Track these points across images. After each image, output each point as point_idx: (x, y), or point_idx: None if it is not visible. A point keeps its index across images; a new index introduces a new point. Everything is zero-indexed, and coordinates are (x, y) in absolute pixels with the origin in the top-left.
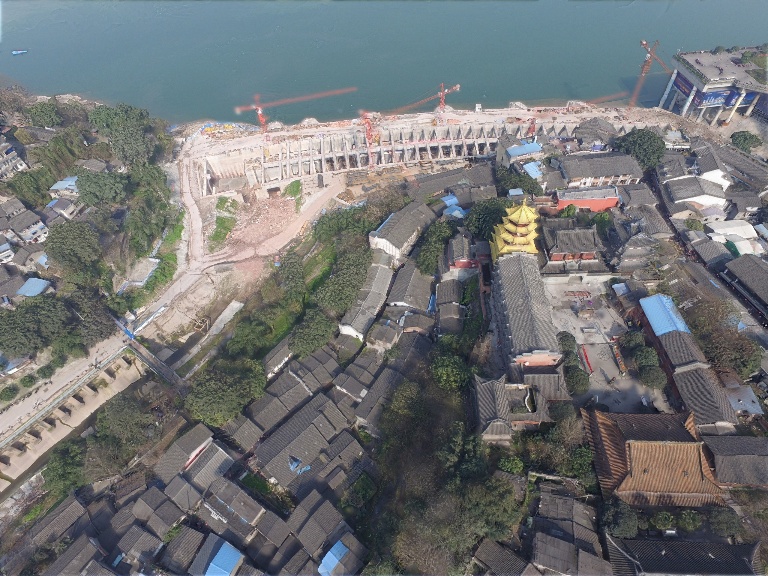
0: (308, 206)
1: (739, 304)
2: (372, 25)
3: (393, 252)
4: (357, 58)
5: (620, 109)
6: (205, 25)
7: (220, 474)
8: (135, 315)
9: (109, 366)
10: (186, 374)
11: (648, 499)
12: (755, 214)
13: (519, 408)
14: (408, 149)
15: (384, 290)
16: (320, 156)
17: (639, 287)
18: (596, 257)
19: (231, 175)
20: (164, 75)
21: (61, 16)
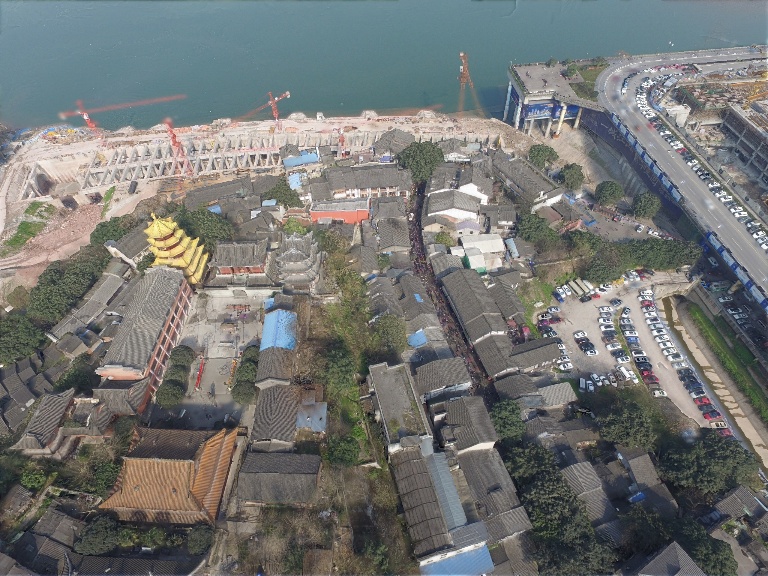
0: (114, 212)
1: (435, 319)
2: (260, 31)
3: (130, 261)
4: (233, 64)
5: (458, 119)
6: (99, 28)
7: None
8: None
9: None
10: None
11: (146, 515)
12: (513, 228)
13: (70, 422)
14: (242, 156)
15: (105, 299)
16: (148, 162)
17: (284, 302)
18: (265, 271)
19: (70, 179)
20: (39, 78)
21: None
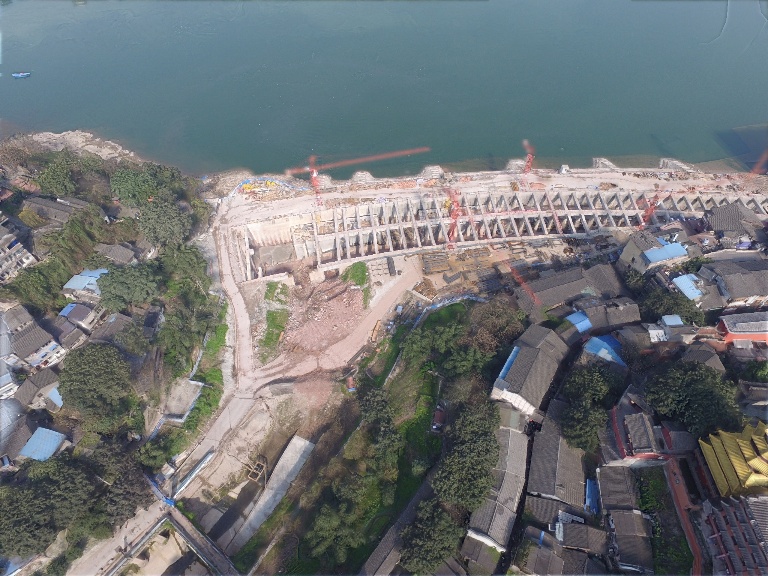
0: (379, 300)
1: None
2: (420, 55)
3: (524, 407)
4: (408, 95)
5: (731, 176)
6: (231, 48)
7: None
8: (174, 466)
9: (143, 549)
10: (248, 569)
11: None
12: None
13: None
14: None
15: (522, 470)
16: (384, 228)
17: None
18: None
19: (274, 242)
20: (188, 109)
21: (68, 32)
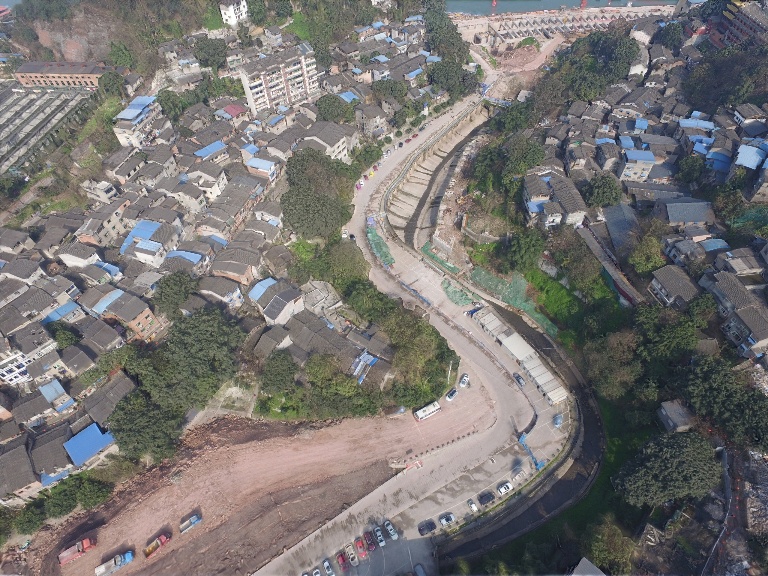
0: (544, 48)
1: None
2: None
3: (644, 41)
4: None
5: None
6: None
7: (603, 114)
8: None
9: None
10: None
11: None
12: None
13: None
14: (588, 27)
15: (648, 55)
16: (534, 28)
17: None
18: None
19: None
20: None
21: None
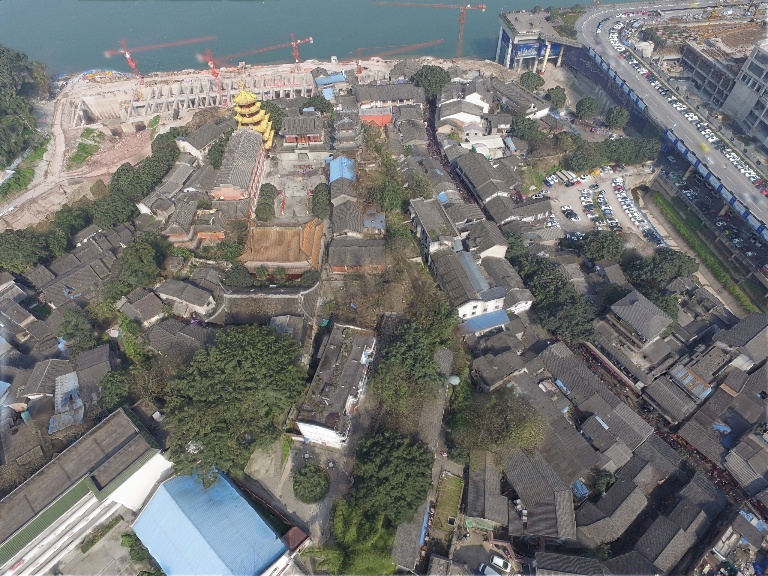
0: None
1: (453, 186)
2: None
3: (197, 154)
4: (247, 20)
5: (456, 61)
6: None
7: None
8: None
9: None
10: None
11: (268, 270)
12: (510, 131)
13: (200, 221)
14: (267, 93)
15: (181, 181)
16: (184, 97)
17: None
18: (322, 140)
19: (110, 116)
20: (64, 33)
21: None
